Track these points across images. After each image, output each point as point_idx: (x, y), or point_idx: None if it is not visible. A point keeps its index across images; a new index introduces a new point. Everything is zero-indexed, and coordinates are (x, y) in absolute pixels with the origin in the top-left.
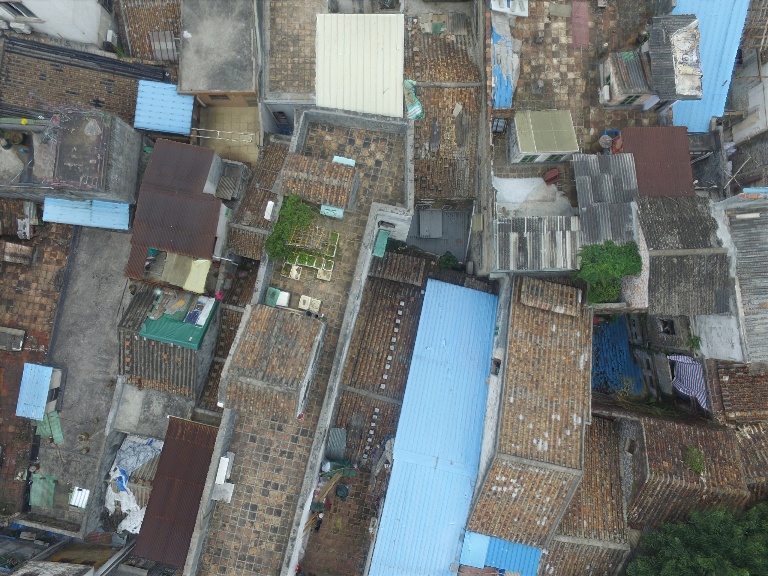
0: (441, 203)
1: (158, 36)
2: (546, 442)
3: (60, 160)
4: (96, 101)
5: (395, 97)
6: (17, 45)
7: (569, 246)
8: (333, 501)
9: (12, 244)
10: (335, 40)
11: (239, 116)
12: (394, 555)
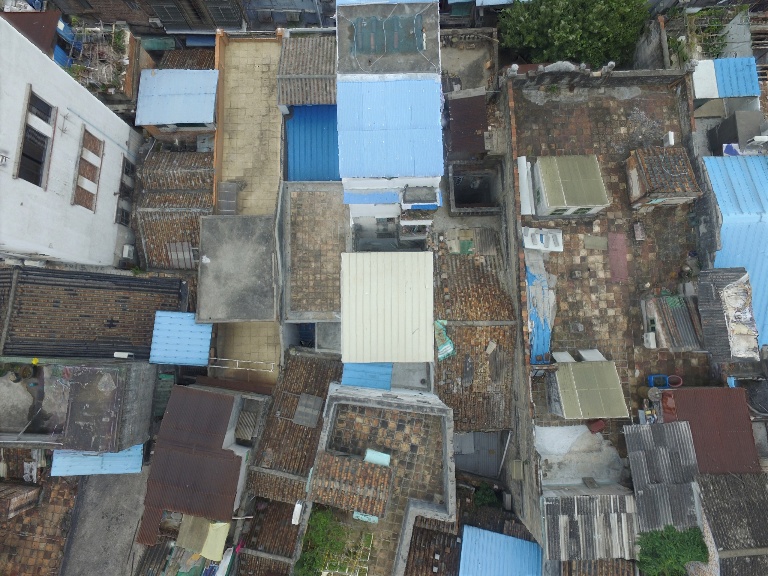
0: None
1: (175, 247)
2: None
3: (71, 418)
4: (110, 321)
5: (425, 338)
6: (31, 274)
7: (626, 532)
8: None
9: (17, 497)
10: (361, 279)
11: (258, 329)
12: None
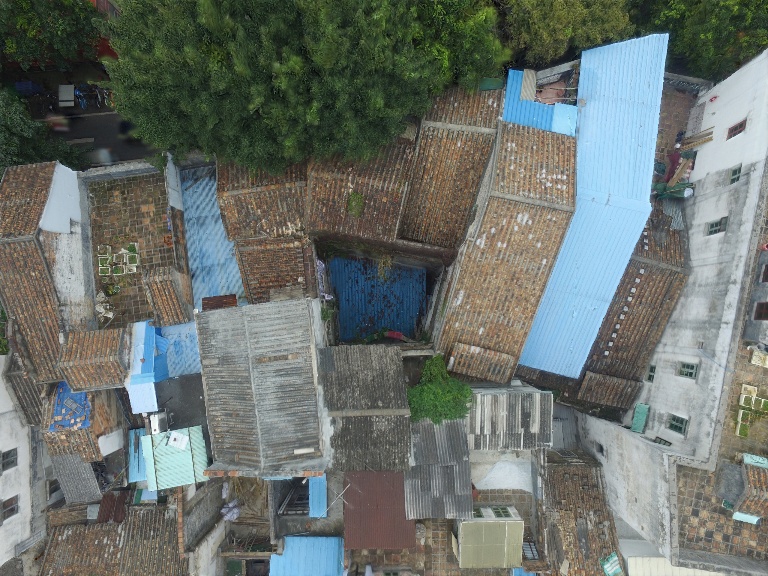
0: (554, 458)
1: None
2: (519, 222)
3: None
4: None
5: None
6: None
7: (478, 418)
8: (665, 159)
9: None
10: None
11: None
12: (639, 114)
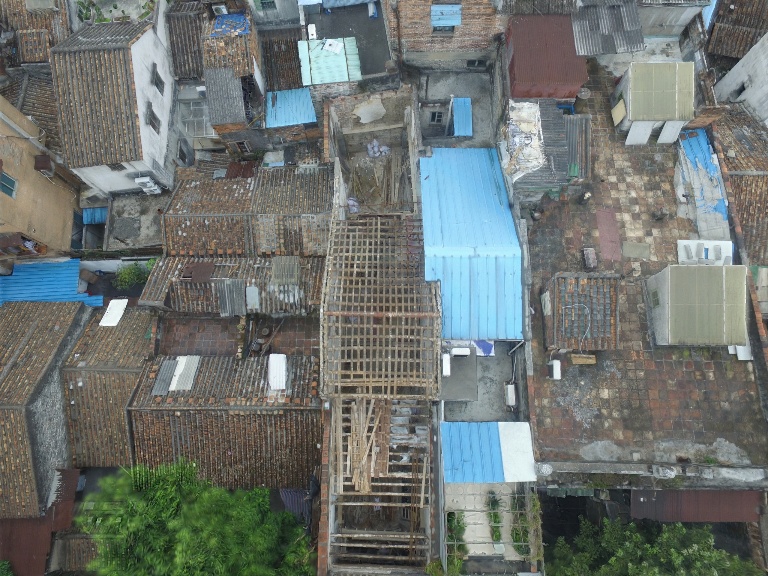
0: None
1: None
2: None
3: None
4: None
5: None
6: None
7: None
8: None
9: None
10: None
11: None
12: None
